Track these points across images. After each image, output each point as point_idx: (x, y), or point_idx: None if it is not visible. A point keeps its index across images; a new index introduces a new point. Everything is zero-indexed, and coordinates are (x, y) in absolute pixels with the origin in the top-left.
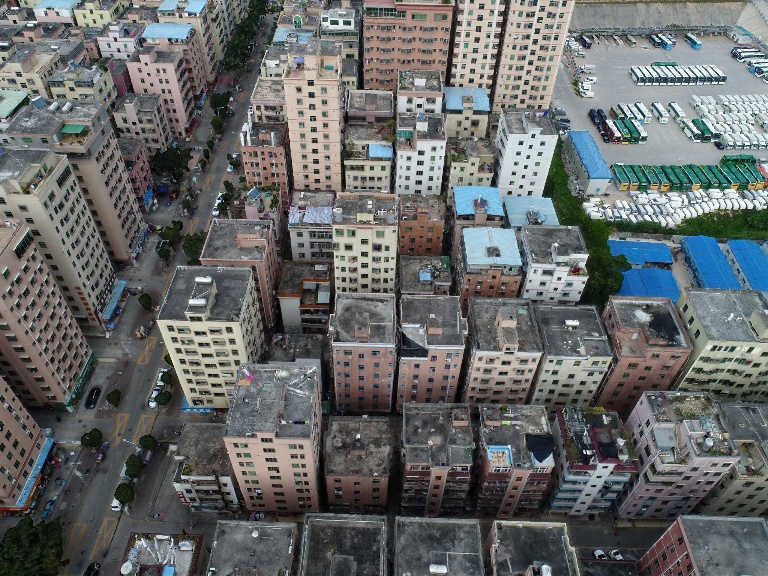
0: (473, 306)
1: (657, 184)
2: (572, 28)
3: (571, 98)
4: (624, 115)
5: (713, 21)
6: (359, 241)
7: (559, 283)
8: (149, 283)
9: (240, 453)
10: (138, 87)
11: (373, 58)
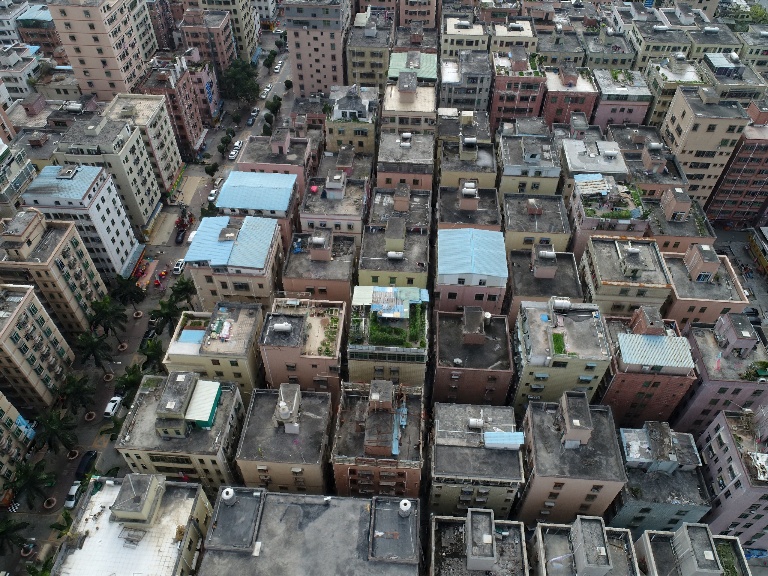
0: None
1: None
2: None
3: None
4: None
5: None
6: None
7: None
8: None
9: None
10: None
11: None
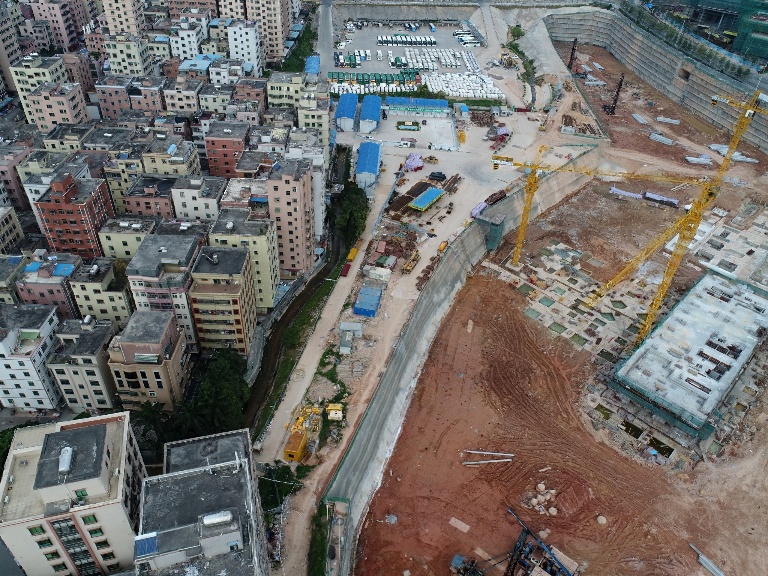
0: (173, 81)
1: (348, 80)
2: (355, 19)
3: (329, 49)
4: (353, 54)
5: (453, 18)
6: (119, 52)
7: (225, 80)
8: None
9: (37, 109)
10: (38, 19)
11: (172, 1)
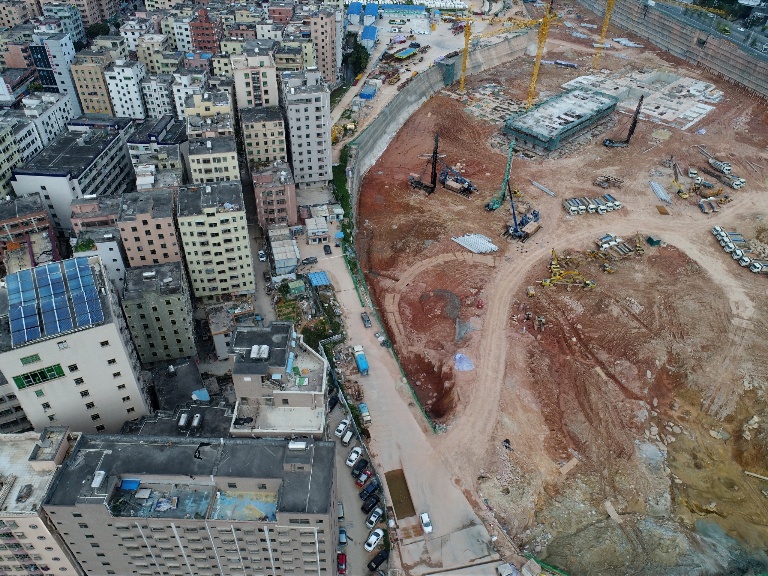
0: None
1: None
2: None
3: None
4: None
5: None
6: None
7: None
8: (137, 8)
9: None
10: None
11: None
